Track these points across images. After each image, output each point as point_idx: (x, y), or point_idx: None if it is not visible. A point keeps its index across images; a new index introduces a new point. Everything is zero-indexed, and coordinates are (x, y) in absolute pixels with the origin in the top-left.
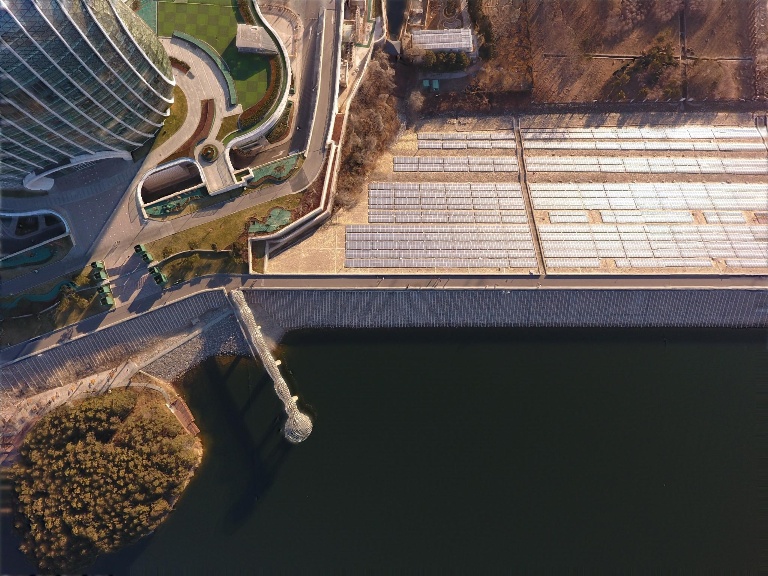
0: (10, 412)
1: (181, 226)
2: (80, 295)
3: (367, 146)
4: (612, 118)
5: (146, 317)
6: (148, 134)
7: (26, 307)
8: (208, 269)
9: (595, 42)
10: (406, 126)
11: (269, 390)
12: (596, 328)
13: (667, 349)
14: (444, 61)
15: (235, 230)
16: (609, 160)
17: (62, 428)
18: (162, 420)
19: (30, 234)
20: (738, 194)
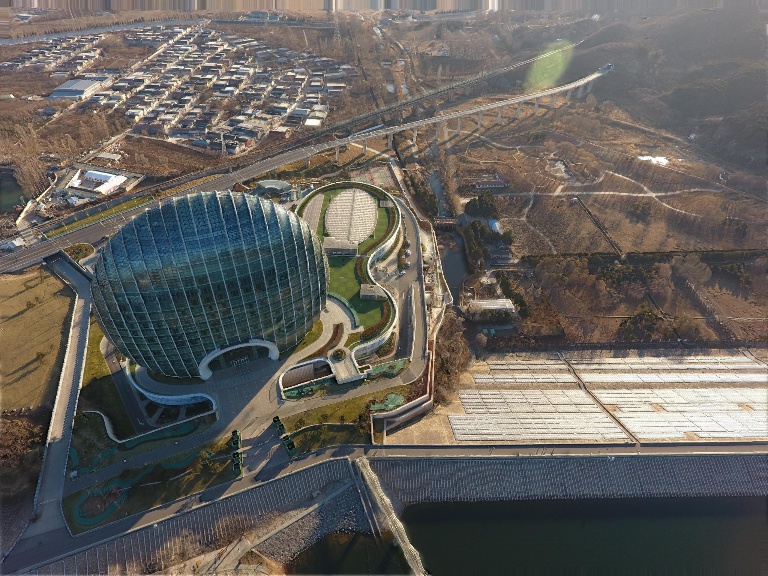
0: None
1: (313, 405)
2: (213, 462)
3: (453, 362)
4: (633, 352)
5: (270, 486)
6: (296, 339)
7: (159, 473)
8: (334, 441)
9: (597, 310)
10: (476, 357)
11: None
12: (712, 498)
13: None
14: (497, 316)
15: (358, 409)
16: (646, 375)
17: None
18: None
19: (169, 423)
20: (766, 394)
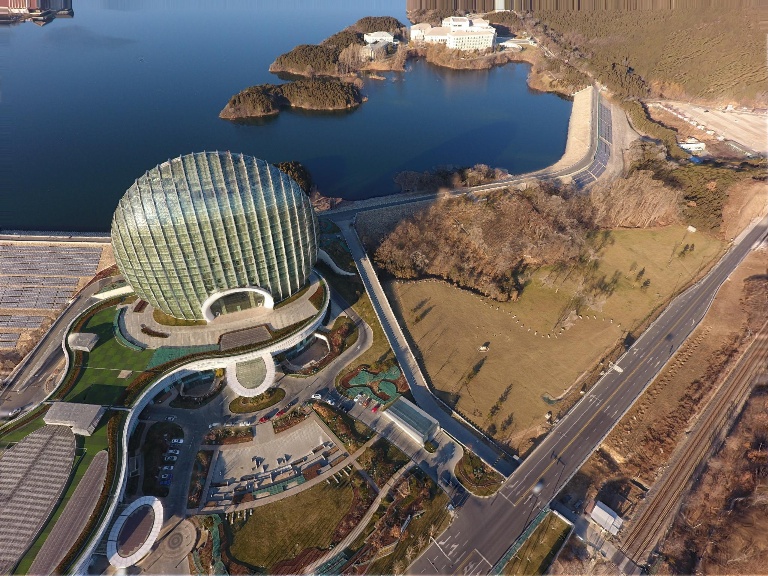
0: None
1: None
2: None
3: None
4: None
5: None
6: None
7: None
8: None
9: None
10: None
11: None
12: None
13: None
14: None
15: None
16: None
17: None
18: None
19: None
20: None
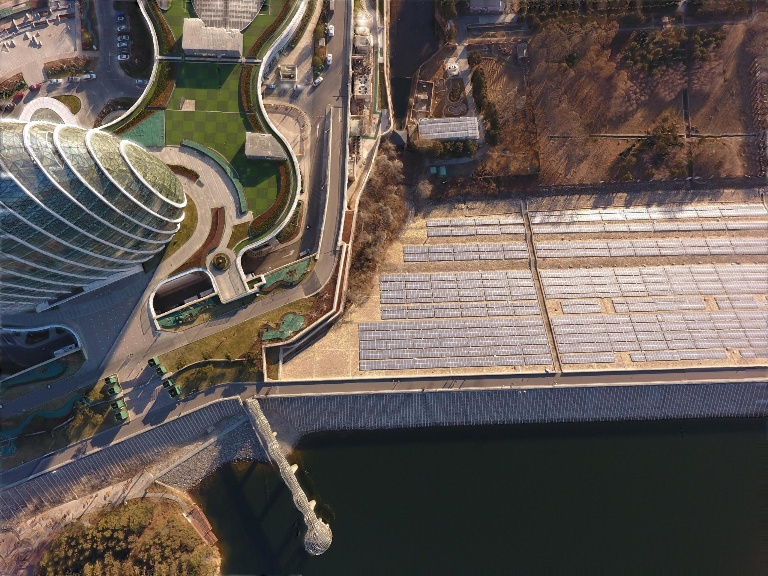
0: (26, 535)
1: (194, 336)
2: (94, 410)
3: (377, 240)
4: (619, 198)
5: (161, 428)
6: (159, 248)
7: (39, 425)
8: (222, 378)
9: (600, 123)
10: (414, 213)
11: (286, 493)
12: (613, 422)
13: (684, 440)
14: (451, 150)
15: (249, 338)
16: (618, 243)
17: (79, 549)
18: (180, 535)
19: (41, 343)
20: (748, 276)
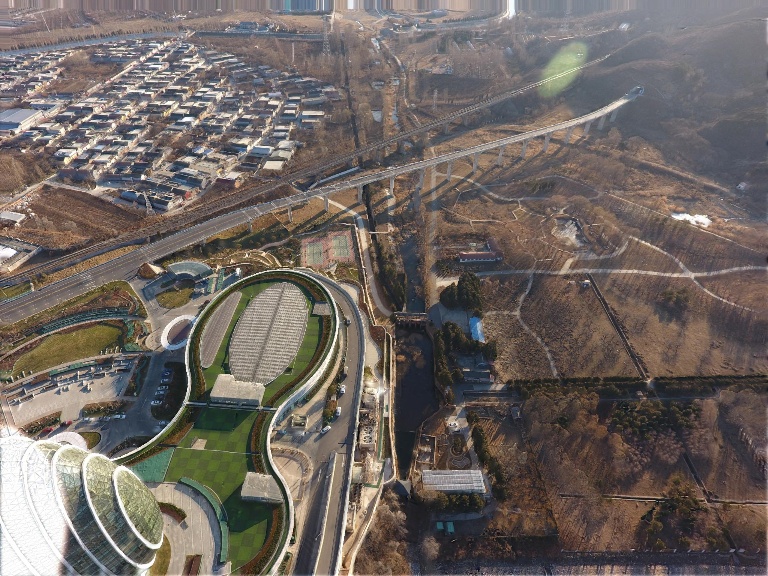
0: None
1: None
2: None
3: None
4: (660, 572)
5: None
6: None
7: None
8: None
9: (609, 483)
10: None
11: None
12: None
13: None
14: (457, 503)
15: None
16: None
17: None
18: None
19: None
20: None
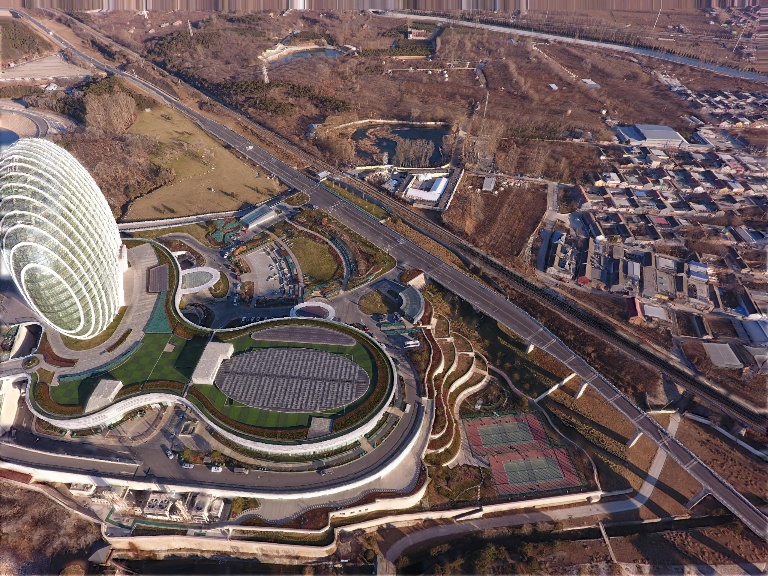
0: None
1: None
2: None
3: None
4: None
5: None
6: None
7: (0, 270)
8: None
9: None
10: (18, 574)
11: None
12: None
13: None
14: None
15: None
16: None
17: None
18: None
19: None
20: None
